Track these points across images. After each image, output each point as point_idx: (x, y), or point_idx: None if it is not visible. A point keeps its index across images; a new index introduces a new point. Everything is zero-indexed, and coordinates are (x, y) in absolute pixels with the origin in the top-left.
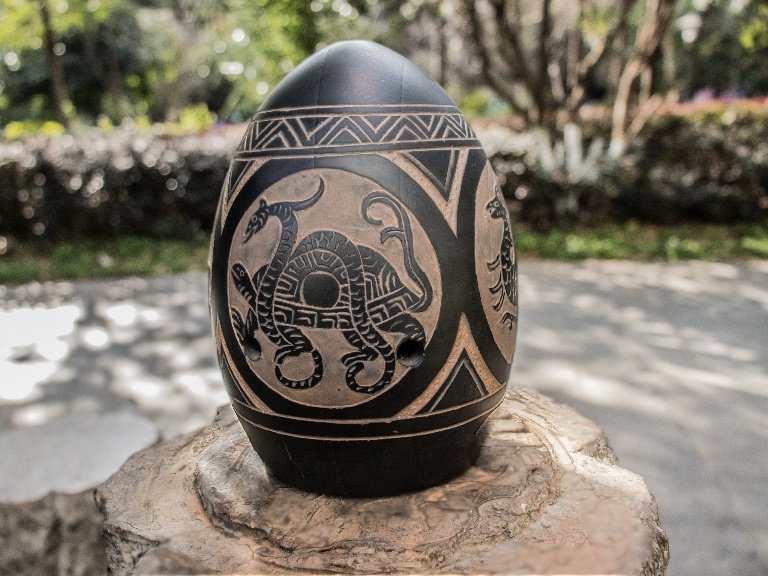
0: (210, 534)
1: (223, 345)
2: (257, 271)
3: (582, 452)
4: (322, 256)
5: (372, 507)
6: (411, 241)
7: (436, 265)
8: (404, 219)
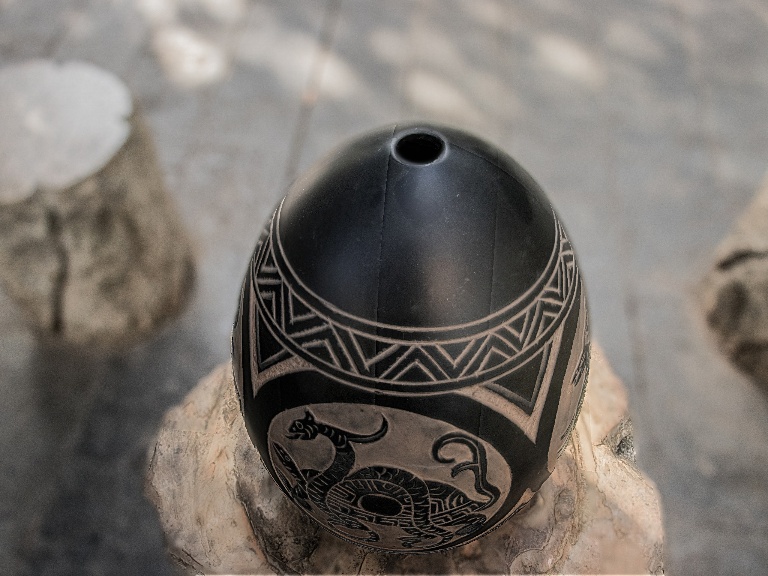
0: (267, 575)
1: (264, 464)
2: (306, 469)
3: (606, 449)
4: (384, 485)
5: (414, 562)
6: (485, 468)
7: (508, 474)
8: (480, 453)
